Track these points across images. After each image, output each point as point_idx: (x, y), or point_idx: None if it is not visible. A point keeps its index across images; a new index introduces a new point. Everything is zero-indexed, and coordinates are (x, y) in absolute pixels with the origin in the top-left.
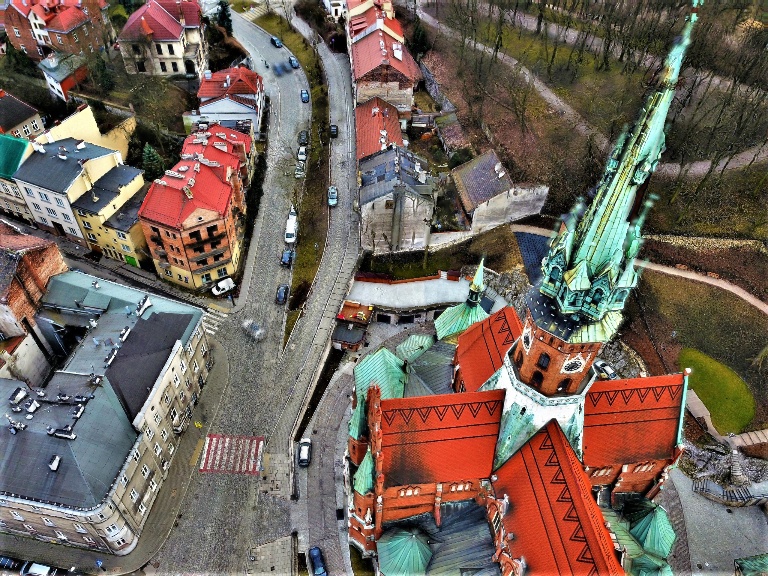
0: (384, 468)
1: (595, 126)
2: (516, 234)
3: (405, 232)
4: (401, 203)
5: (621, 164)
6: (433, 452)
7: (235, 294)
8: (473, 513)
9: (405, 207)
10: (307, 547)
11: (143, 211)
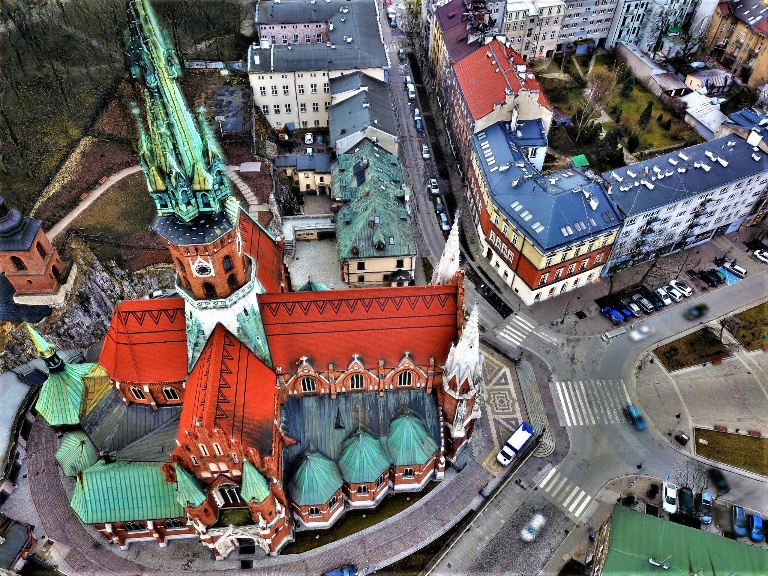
0: None
1: None
2: None
3: None
4: None
5: (155, 74)
6: (252, 409)
7: None
8: (292, 408)
9: None
10: None
11: None
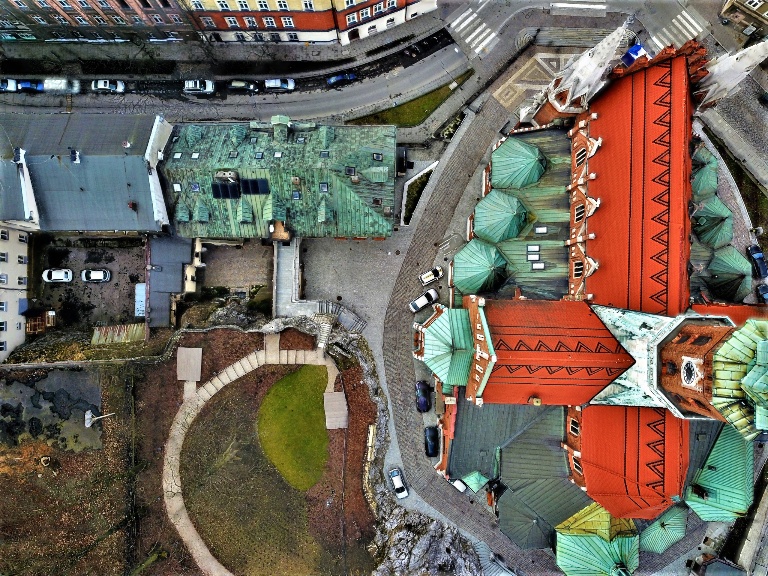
0: None
1: None
2: None
3: None
4: None
5: None
6: None
7: None
8: None
9: None
10: None
11: None
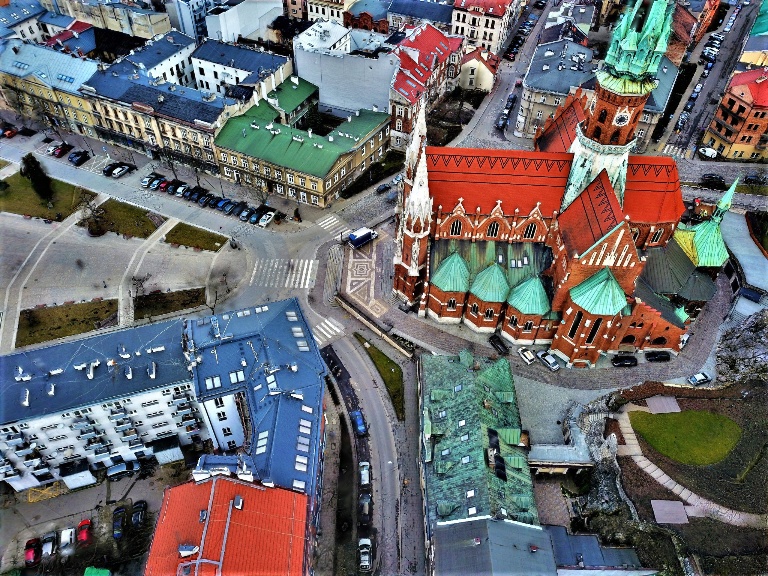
0: (546, 132)
1: None
2: None
3: None
4: None
5: None
6: (556, 143)
7: (703, 158)
8: None
9: None
10: None
11: (738, 74)
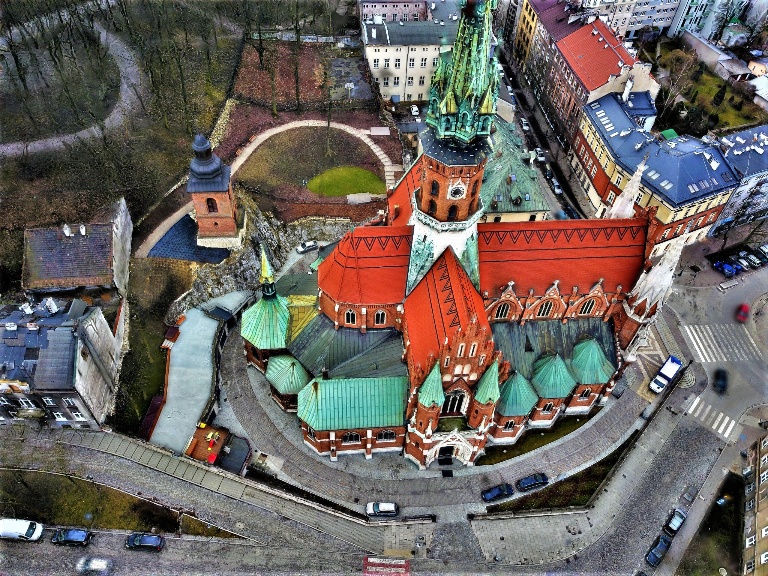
0: None
1: (20, 141)
2: (151, 255)
3: (106, 362)
4: (87, 340)
5: None
6: None
7: None
8: None
9: (91, 339)
10: (480, 505)
11: None
